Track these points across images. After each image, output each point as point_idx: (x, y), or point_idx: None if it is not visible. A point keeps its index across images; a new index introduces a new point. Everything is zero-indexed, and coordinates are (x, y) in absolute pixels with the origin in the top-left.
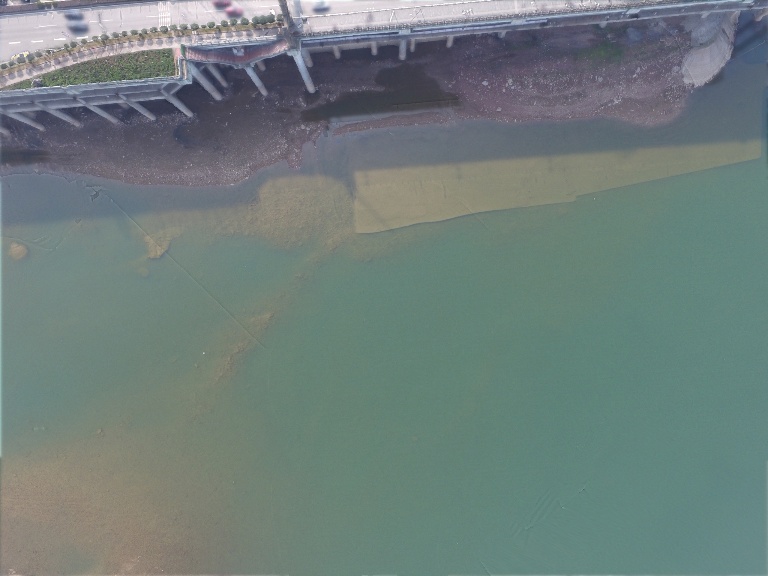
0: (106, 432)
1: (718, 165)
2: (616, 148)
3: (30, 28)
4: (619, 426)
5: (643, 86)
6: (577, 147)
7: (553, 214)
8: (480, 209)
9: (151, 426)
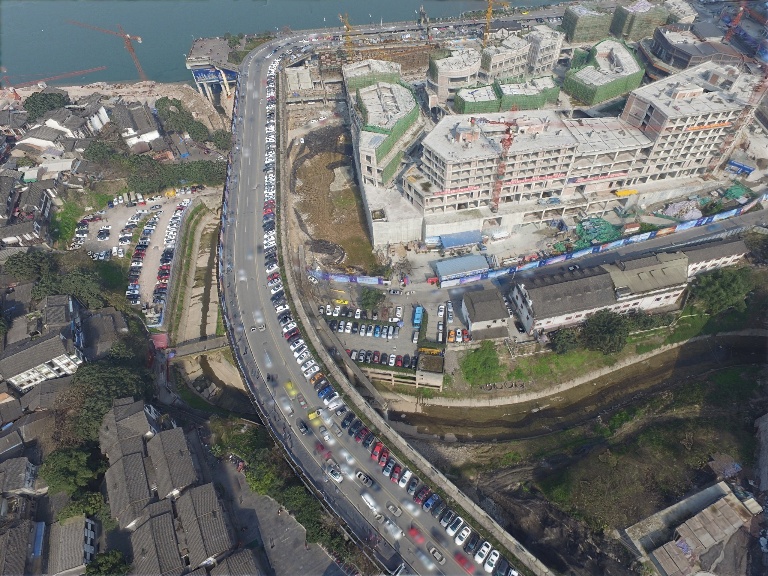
0: (484, 3)
1: None
2: None
3: (525, 18)
4: (298, 7)
5: None
6: None
7: None
8: None
9: (468, 5)
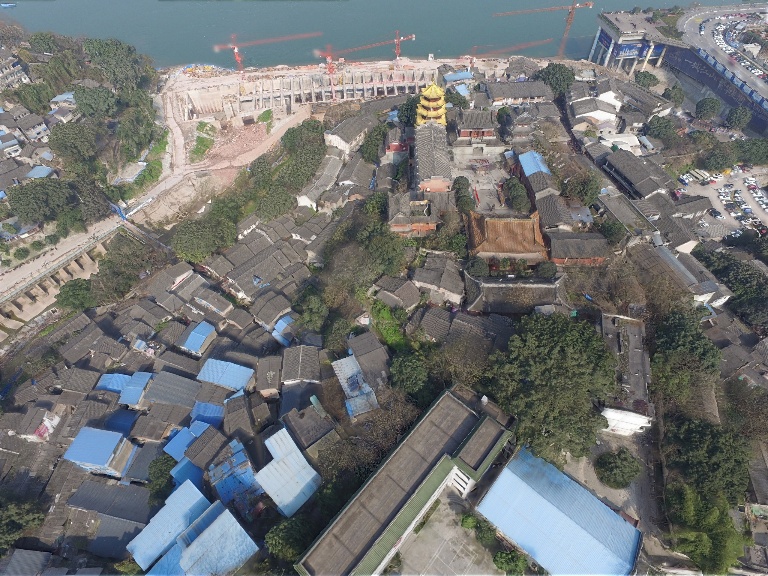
0: None
1: None
2: None
3: None
4: None
5: None
6: None
7: None
8: None
9: None
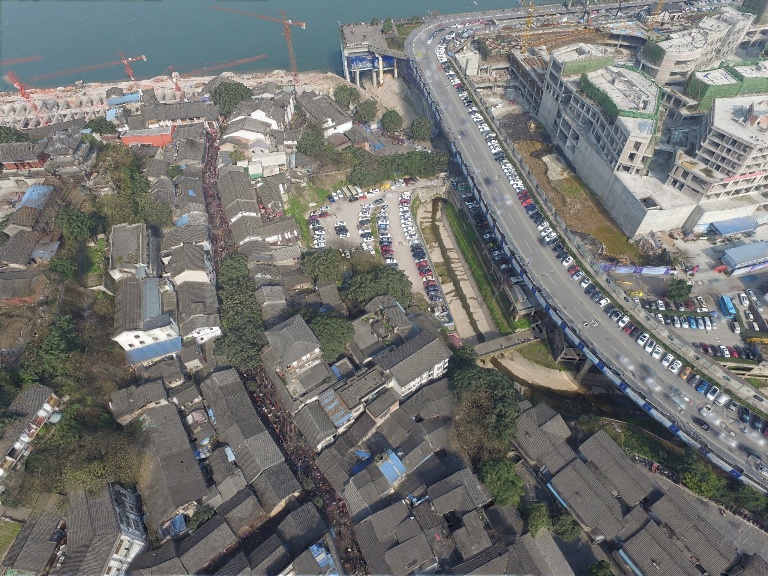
0: None
1: None
2: None
3: None
4: None
5: None
6: None
7: None
8: None
9: None
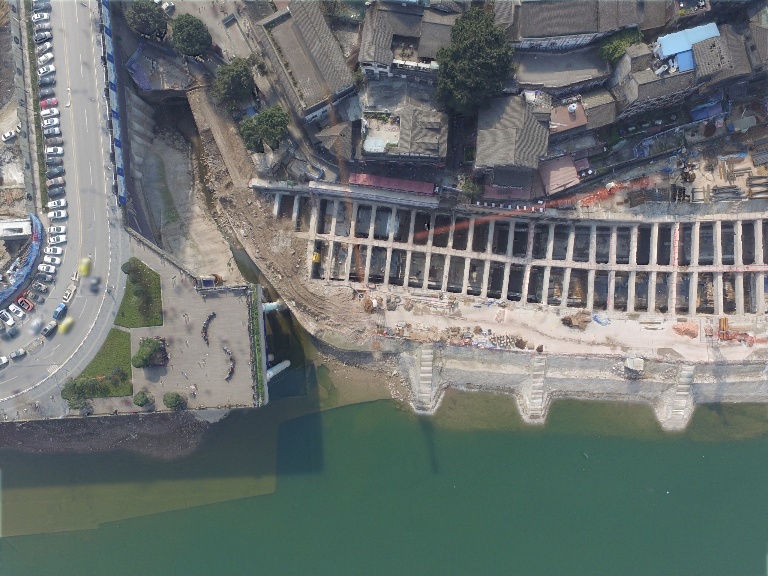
0: None
1: (234, 498)
2: (137, 479)
3: None
4: None
5: (154, 425)
6: (100, 476)
7: (79, 539)
8: (8, 533)
9: None
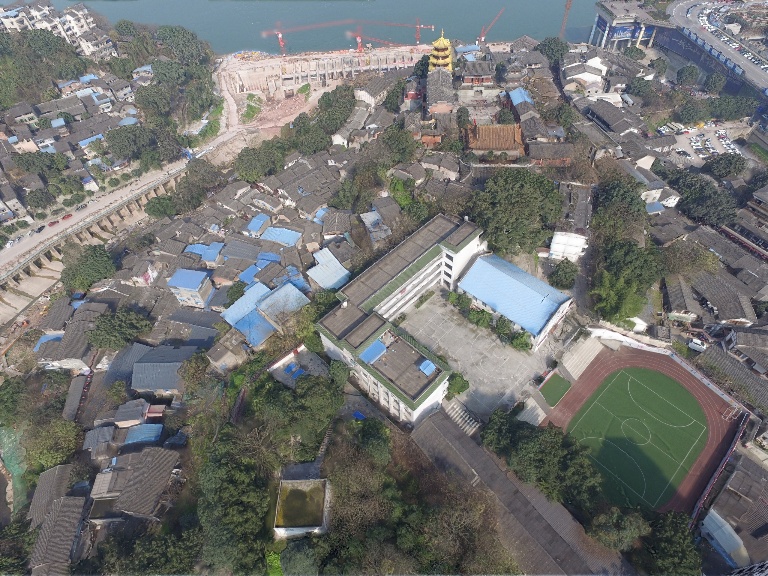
0: None
1: None
2: None
3: None
4: None
5: None
6: None
7: None
8: None
9: None
